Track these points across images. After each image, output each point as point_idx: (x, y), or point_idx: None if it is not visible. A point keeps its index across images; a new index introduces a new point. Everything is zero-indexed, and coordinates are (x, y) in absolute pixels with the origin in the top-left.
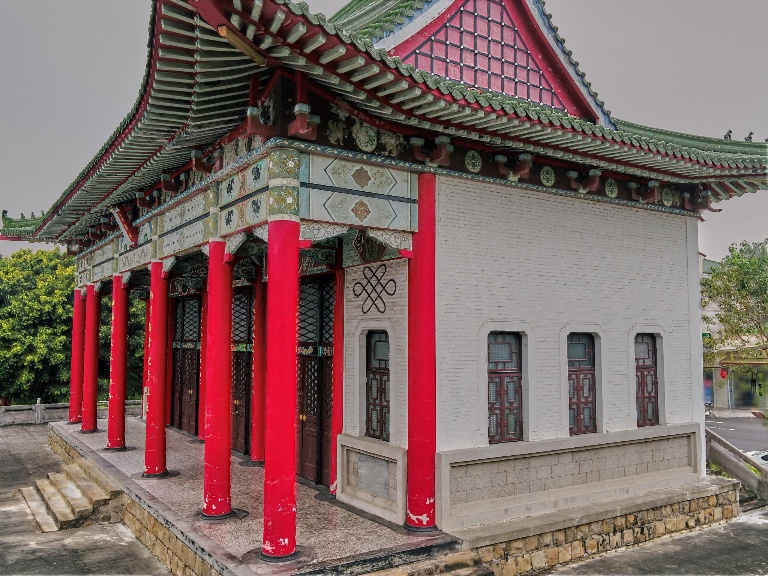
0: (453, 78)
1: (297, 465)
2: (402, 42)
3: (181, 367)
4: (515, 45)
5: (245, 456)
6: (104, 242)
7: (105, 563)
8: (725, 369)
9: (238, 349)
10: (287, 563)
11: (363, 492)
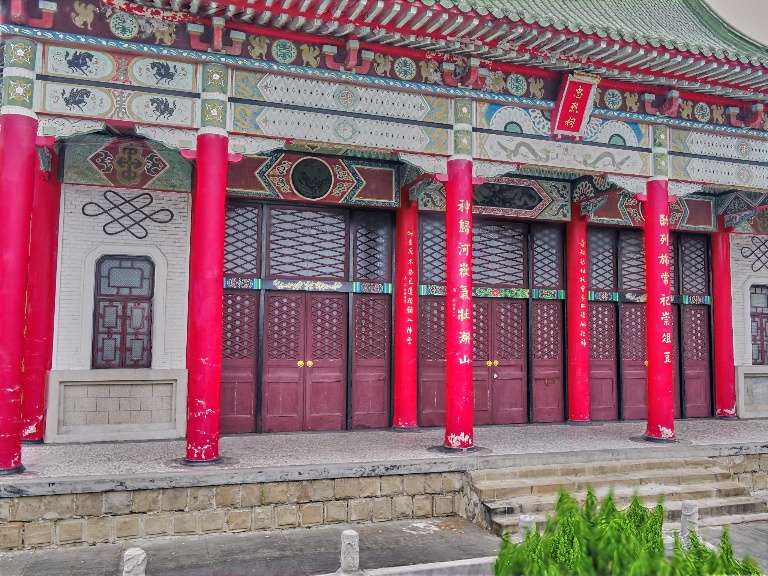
0: None
1: (642, 410)
2: None
3: (263, 323)
4: None
5: (539, 424)
6: (401, 86)
7: None
8: None
9: (509, 295)
10: None
11: (764, 405)
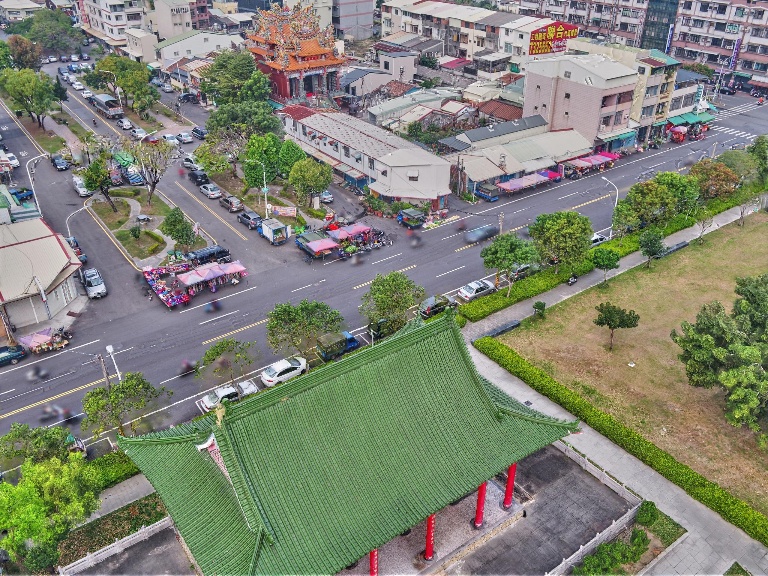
0: None
1: None
2: None
3: None
4: None
5: None
6: None
7: (482, 559)
8: None
9: None
10: (512, 503)
11: None
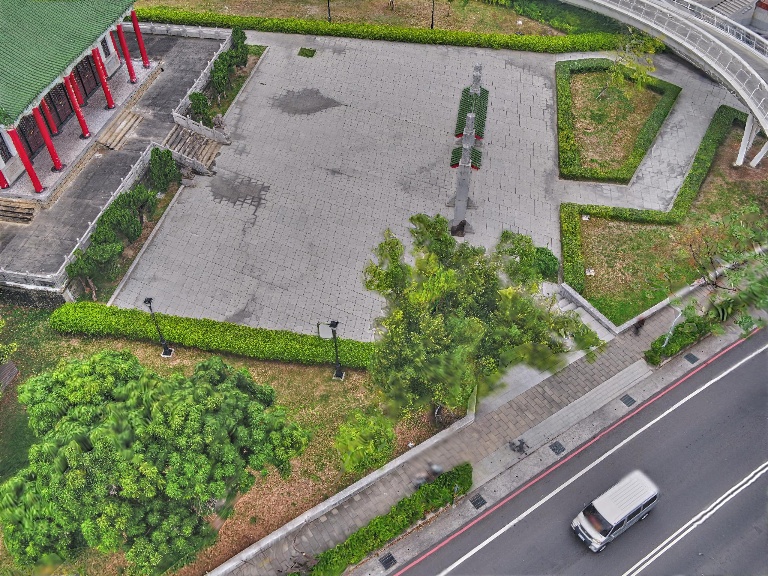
0: None
1: None
2: None
3: None
4: None
5: None
6: None
7: (149, 99)
8: None
9: None
10: None
11: None
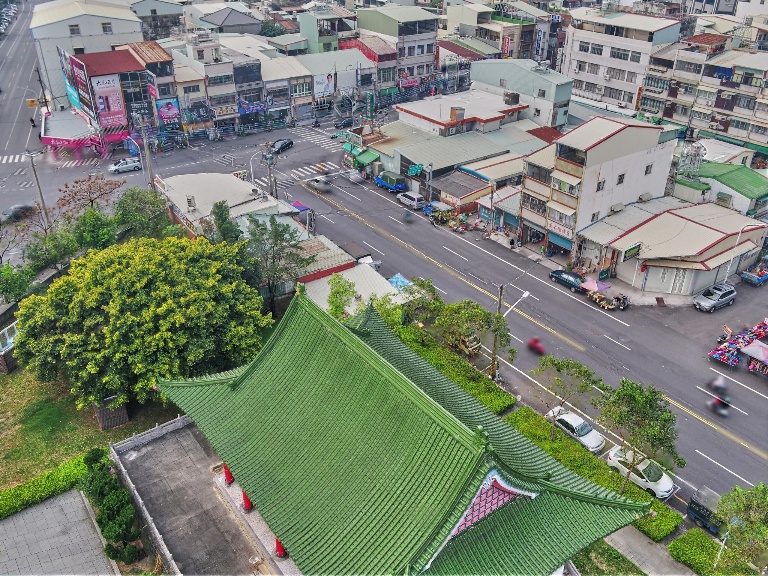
0: (461, 530)
1: None
2: (440, 550)
3: None
4: (493, 493)
5: None
6: None
7: None
8: (645, 266)
9: None
10: None
11: None
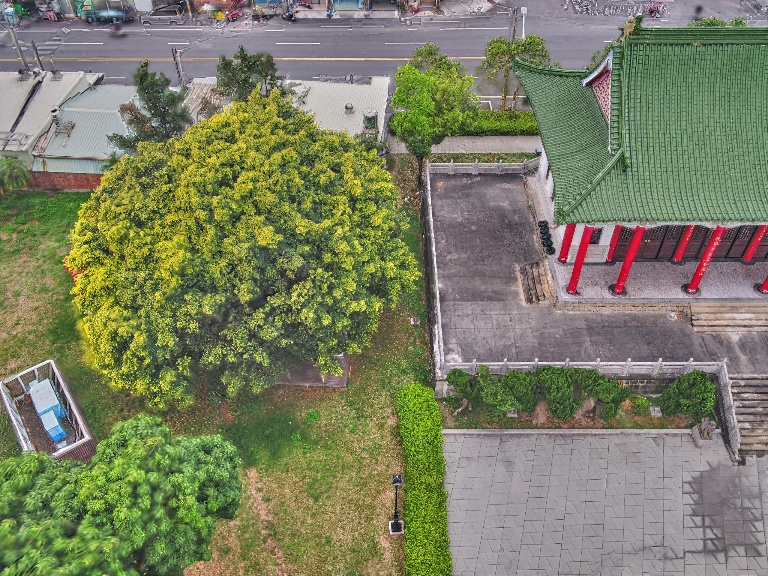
0: None
1: None
2: None
3: None
4: None
5: (729, 259)
6: None
7: None
8: None
9: None
10: None
11: None
